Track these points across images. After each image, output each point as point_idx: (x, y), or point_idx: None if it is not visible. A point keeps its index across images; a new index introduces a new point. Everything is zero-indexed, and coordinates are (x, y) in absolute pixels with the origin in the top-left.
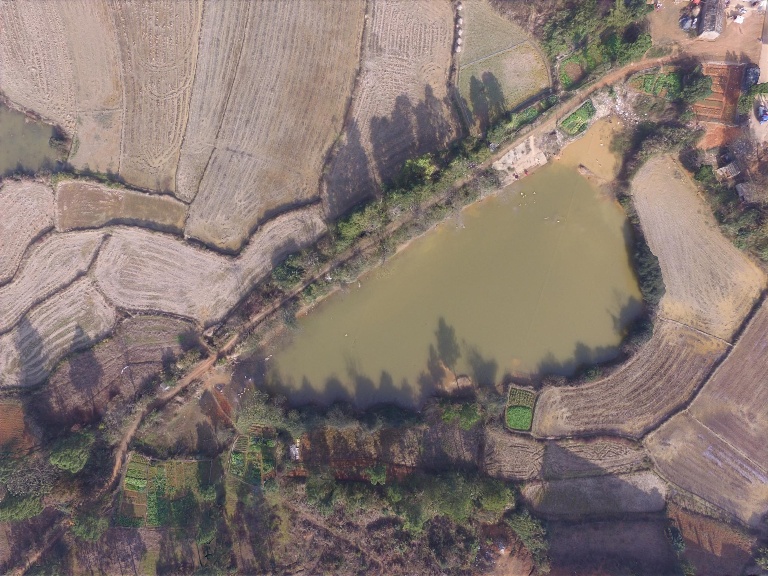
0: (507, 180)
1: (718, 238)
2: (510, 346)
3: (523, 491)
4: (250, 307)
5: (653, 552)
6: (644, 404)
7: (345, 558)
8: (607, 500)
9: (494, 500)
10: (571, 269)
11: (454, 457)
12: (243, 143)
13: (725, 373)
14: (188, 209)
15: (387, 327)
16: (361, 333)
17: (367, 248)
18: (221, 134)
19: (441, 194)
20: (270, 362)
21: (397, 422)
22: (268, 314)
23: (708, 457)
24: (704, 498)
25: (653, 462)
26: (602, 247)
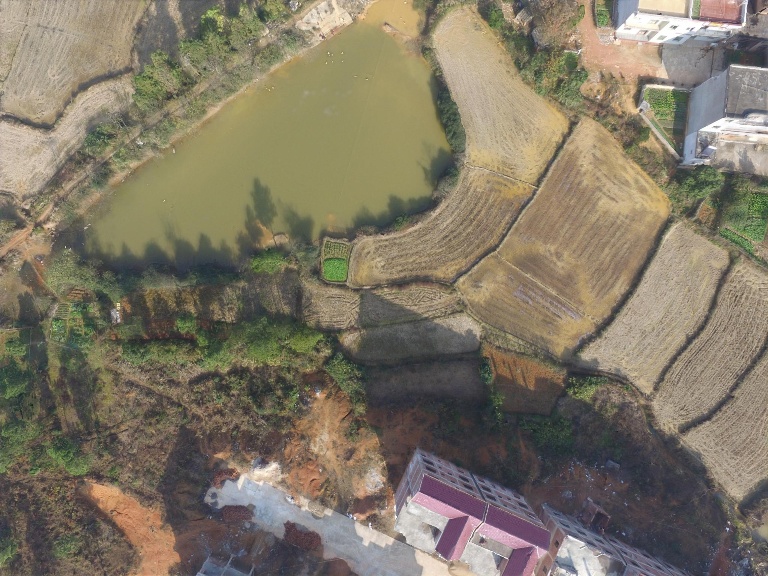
0: (314, 41)
1: (520, 86)
2: (325, 202)
3: (341, 340)
4: (64, 176)
5: (469, 390)
6: (455, 249)
7: (167, 414)
8: (423, 343)
9: (297, 338)
10: (381, 124)
11: (273, 311)
12: (54, 19)
13: (532, 215)
14: (2, 86)
15: (204, 191)
16: (179, 198)
17: (176, 111)
18: (31, 11)
19: (246, 55)
20: (89, 231)
21: (211, 277)
22: (81, 181)
23: (519, 296)
24: (517, 336)
25: (466, 304)
26: (410, 102)
